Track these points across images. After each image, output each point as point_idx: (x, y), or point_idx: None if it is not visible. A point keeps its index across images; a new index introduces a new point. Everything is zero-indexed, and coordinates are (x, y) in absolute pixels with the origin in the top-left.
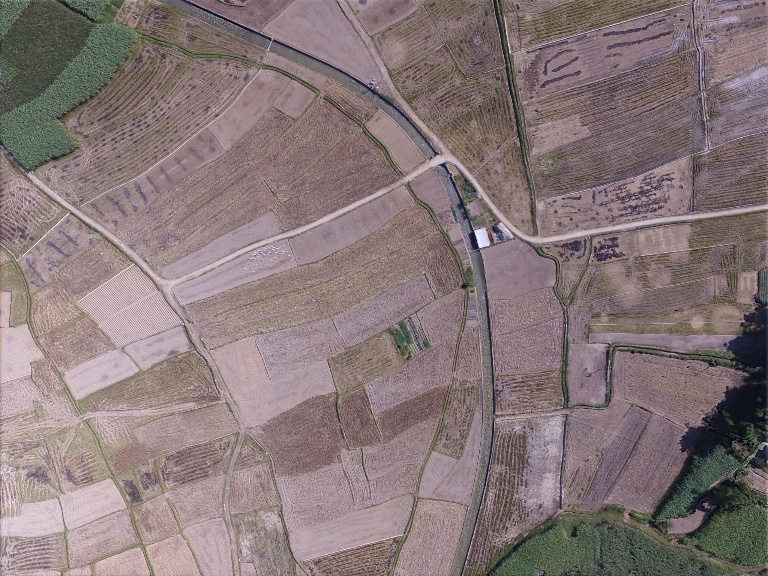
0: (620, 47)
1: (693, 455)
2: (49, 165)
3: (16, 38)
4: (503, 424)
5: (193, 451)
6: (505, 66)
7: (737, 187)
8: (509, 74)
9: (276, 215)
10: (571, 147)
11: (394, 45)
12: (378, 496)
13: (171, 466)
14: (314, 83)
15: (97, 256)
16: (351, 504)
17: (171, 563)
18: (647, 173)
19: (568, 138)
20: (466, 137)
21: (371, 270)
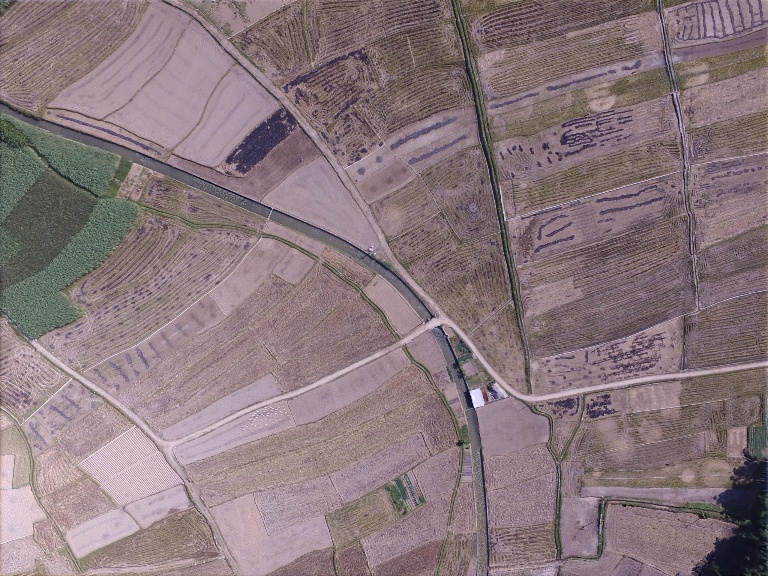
0: (613, 212)
1: None
2: (53, 333)
3: (21, 215)
4: (497, 575)
5: None
6: (500, 232)
7: (727, 346)
8: (504, 240)
9: (275, 377)
10: (564, 309)
11: (392, 213)
12: None
13: None
14: (313, 250)
15: (99, 419)
16: None
17: None
18: (639, 333)
19: (561, 300)
20: (462, 300)
21: (368, 429)
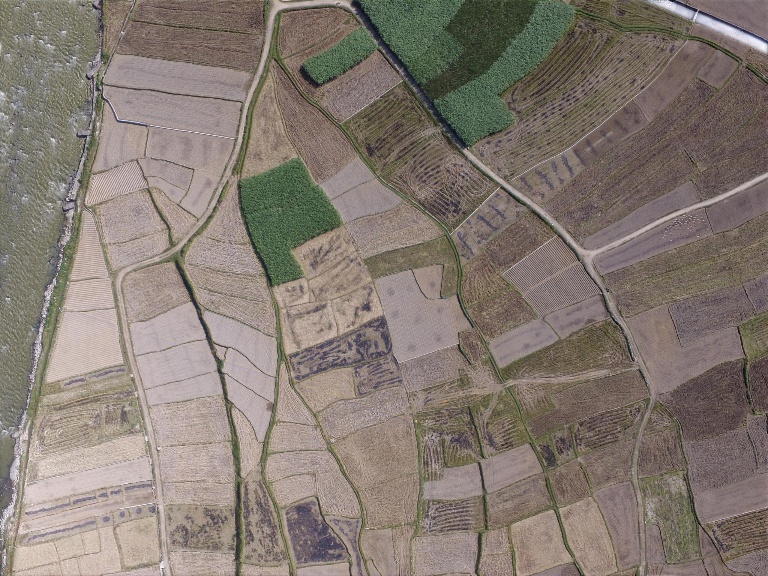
0: None
1: None
2: (483, 141)
3: (465, 18)
4: None
5: (605, 417)
6: None
7: None
8: None
9: (695, 184)
10: None
11: None
12: None
13: (584, 431)
14: (737, 52)
15: (523, 228)
16: (754, 468)
17: (582, 525)
18: None
19: None
20: None
21: None
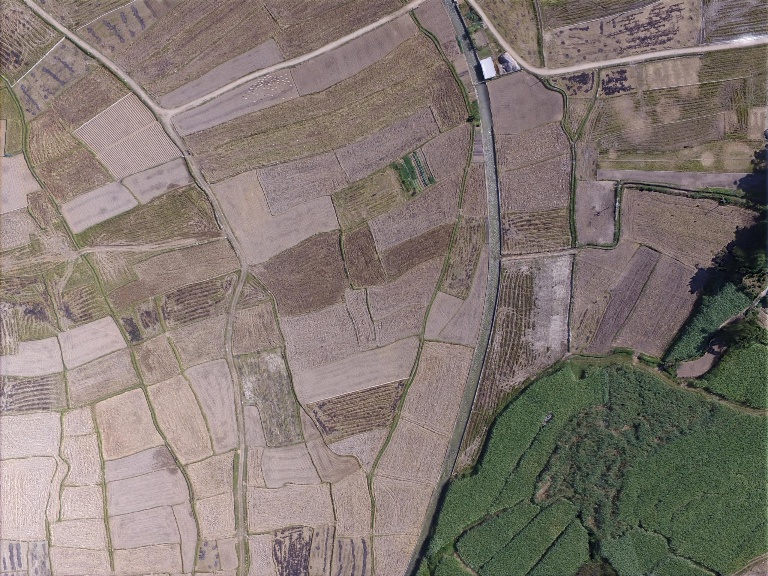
0: None
1: (703, 296)
2: None
3: None
4: (510, 264)
5: (194, 289)
6: None
7: (747, 19)
8: None
9: (277, 43)
10: None
11: None
12: (383, 338)
13: (172, 304)
14: None
15: (94, 84)
16: (356, 346)
17: (173, 405)
18: (656, 3)
19: None
20: None
21: (375, 102)
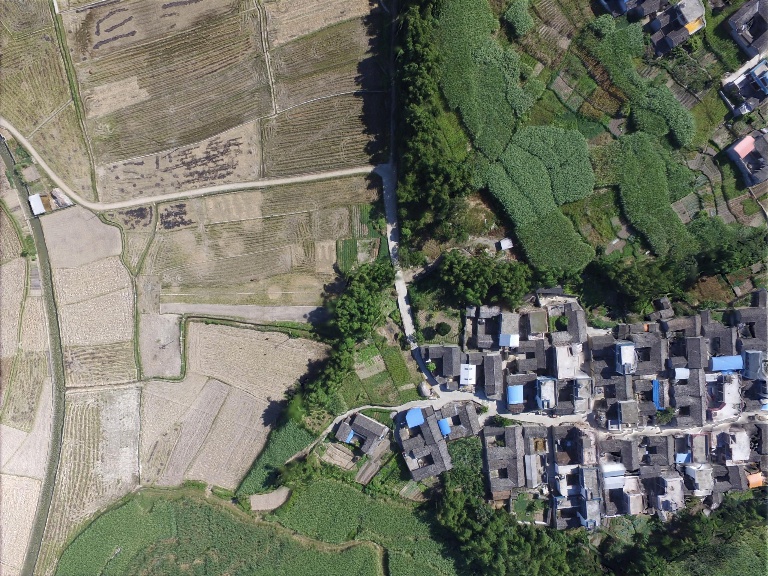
0: (176, 6)
1: (273, 429)
2: None
3: None
4: (75, 397)
5: None
6: (54, 26)
7: (310, 152)
8: (57, 34)
9: None
10: (130, 110)
11: None
12: None
13: None
14: None
15: None
16: None
17: None
18: (212, 138)
19: (126, 101)
20: (17, 100)
21: None
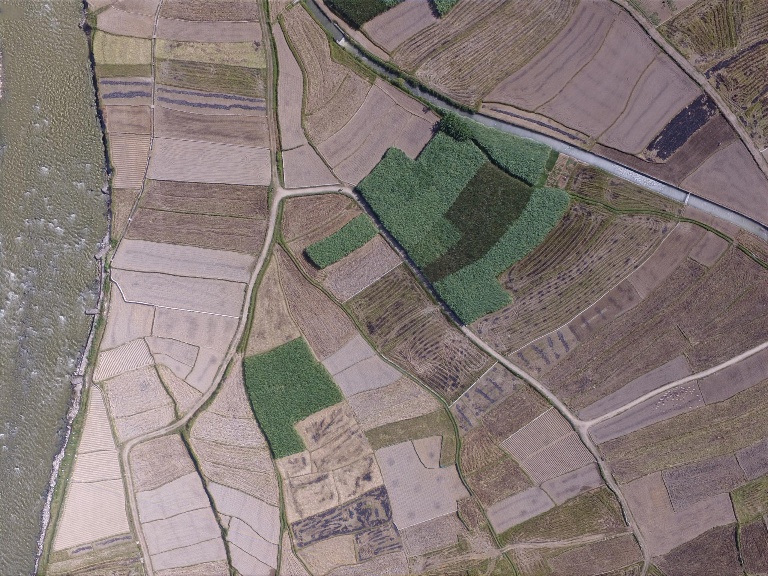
0: None
1: None
2: (481, 318)
3: (464, 205)
4: None
5: None
6: None
7: None
8: None
9: (687, 358)
10: None
11: None
12: None
13: None
14: (727, 233)
15: (520, 400)
16: None
17: None
18: None
19: None
20: None
21: None
